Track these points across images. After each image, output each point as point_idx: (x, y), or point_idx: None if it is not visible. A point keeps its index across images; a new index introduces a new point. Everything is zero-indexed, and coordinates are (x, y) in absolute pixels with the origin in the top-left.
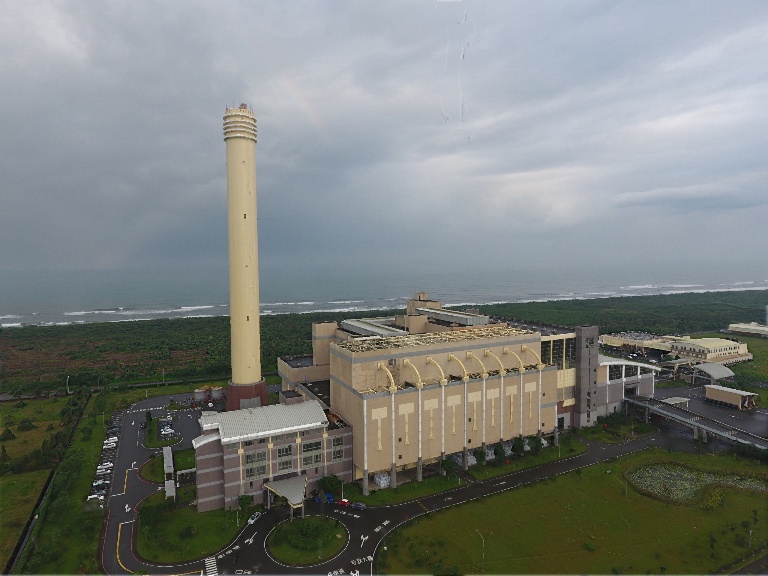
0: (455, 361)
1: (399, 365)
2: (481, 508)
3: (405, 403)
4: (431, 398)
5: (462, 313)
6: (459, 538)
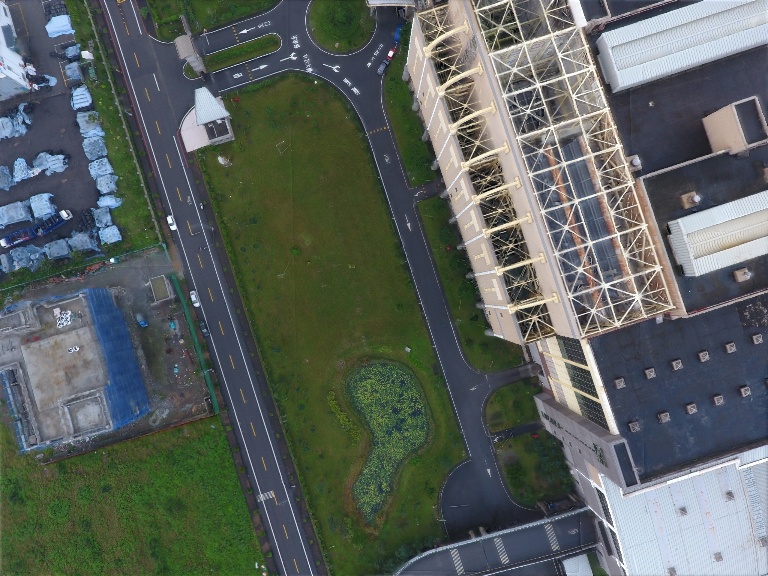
0: (507, 157)
1: (475, 57)
2: (364, 184)
3: (431, 80)
4: (444, 118)
5: (765, 236)
6: (322, 148)
